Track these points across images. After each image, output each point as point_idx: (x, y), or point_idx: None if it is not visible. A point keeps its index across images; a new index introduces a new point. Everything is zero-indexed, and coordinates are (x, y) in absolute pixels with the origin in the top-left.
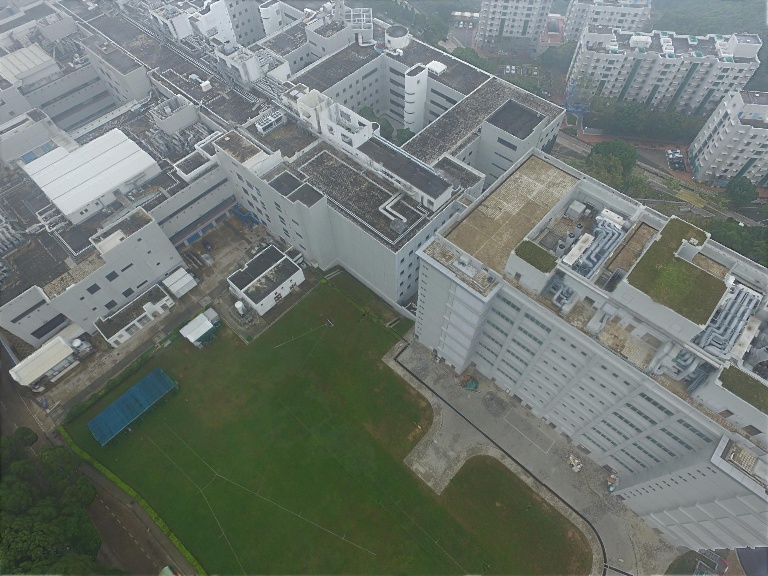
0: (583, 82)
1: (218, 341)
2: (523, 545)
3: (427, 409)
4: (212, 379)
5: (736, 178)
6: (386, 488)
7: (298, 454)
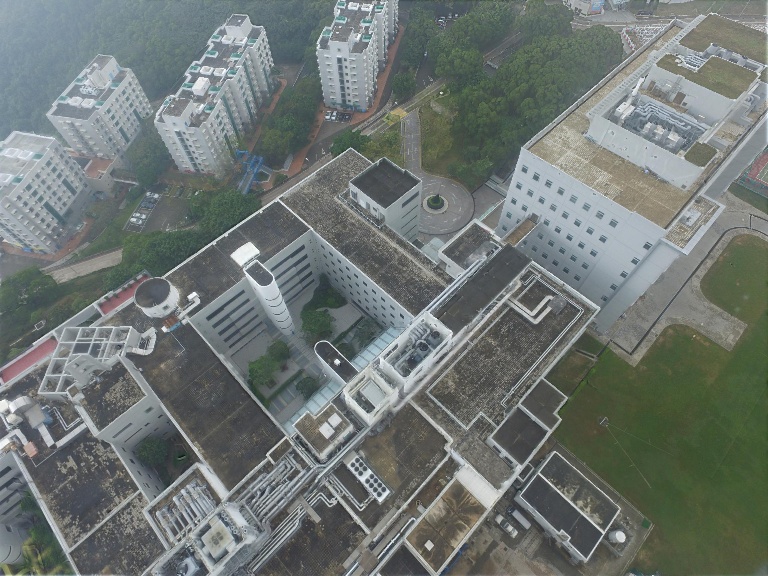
0: (218, 151)
1: (660, 570)
2: (761, 272)
3: (675, 329)
4: (713, 569)
5: (394, 81)
6: (760, 366)
7: (762, 450)
